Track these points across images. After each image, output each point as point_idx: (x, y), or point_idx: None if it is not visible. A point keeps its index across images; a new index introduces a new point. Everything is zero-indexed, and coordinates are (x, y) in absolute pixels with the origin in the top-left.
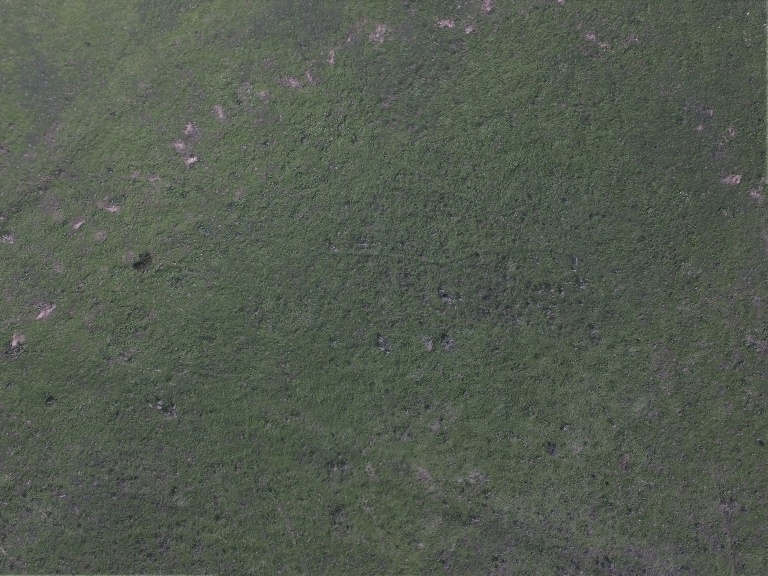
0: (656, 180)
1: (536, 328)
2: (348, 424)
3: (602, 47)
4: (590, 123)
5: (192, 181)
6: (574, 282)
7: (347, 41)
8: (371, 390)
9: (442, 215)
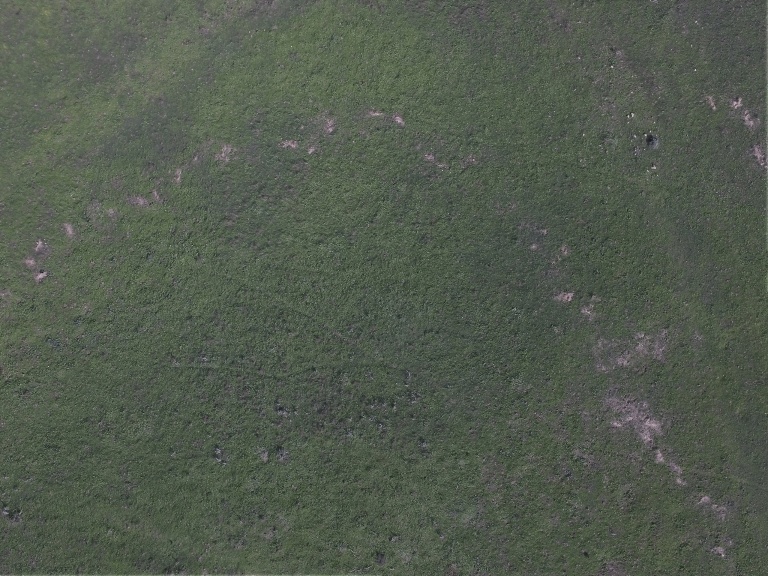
0: (489, 297)
1: (368, 441)
2: (185, 532)
3: (440, 167)
4: (426, 241)
5: (41, 295)
6: (407, 396)
7: (194, 160)
8: (208, 499)
9: (280, 330)
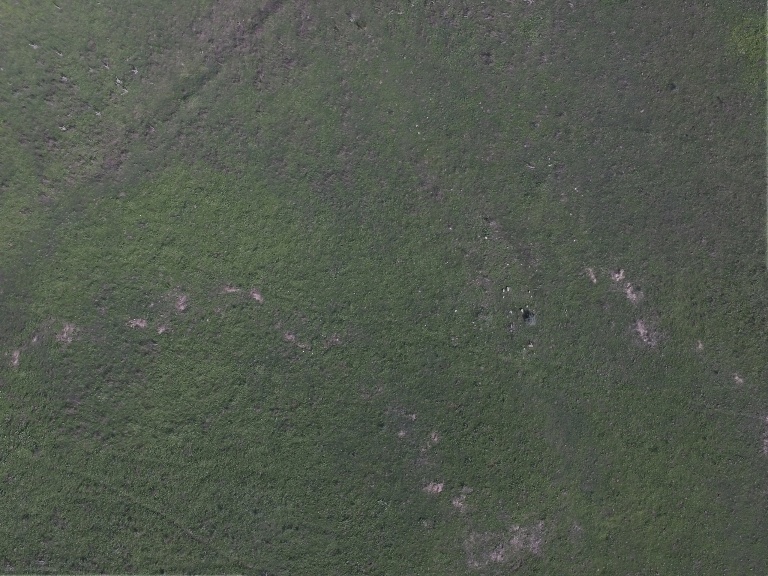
0: (353, 489)
1: None
2: None
3: (301, 348)
4: (285, 429)
5: None
6: None
7: (33, 341)
8: None
9: (125, 529)
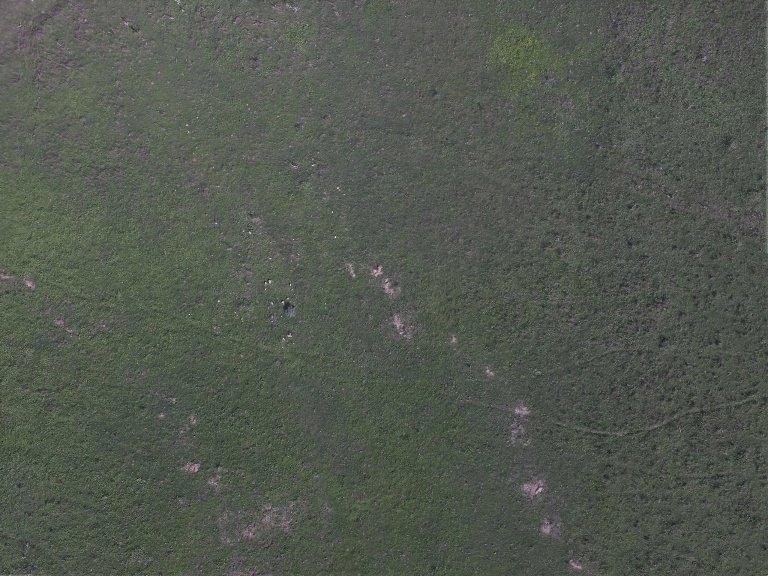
0: (114, 467)
1: None
2: None
3: (70, 332)
4: (51, 409)
5: None
6: (24, 568)
7: None
8: None
9: None
